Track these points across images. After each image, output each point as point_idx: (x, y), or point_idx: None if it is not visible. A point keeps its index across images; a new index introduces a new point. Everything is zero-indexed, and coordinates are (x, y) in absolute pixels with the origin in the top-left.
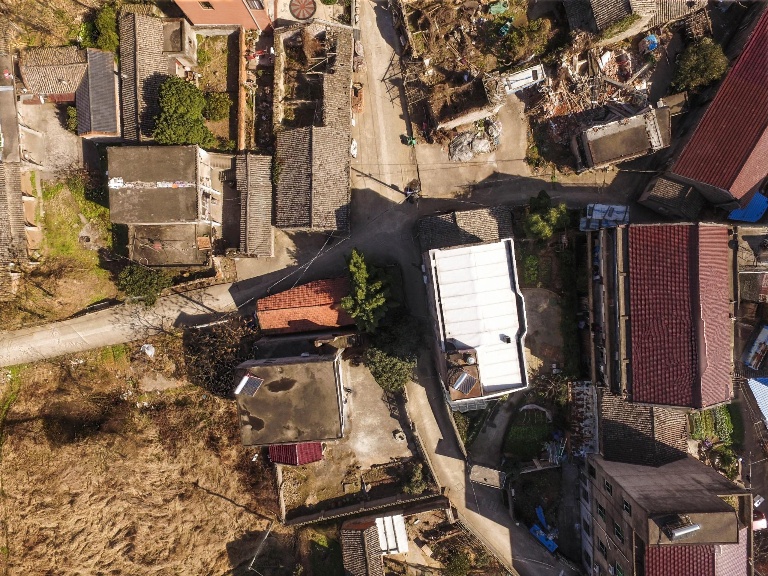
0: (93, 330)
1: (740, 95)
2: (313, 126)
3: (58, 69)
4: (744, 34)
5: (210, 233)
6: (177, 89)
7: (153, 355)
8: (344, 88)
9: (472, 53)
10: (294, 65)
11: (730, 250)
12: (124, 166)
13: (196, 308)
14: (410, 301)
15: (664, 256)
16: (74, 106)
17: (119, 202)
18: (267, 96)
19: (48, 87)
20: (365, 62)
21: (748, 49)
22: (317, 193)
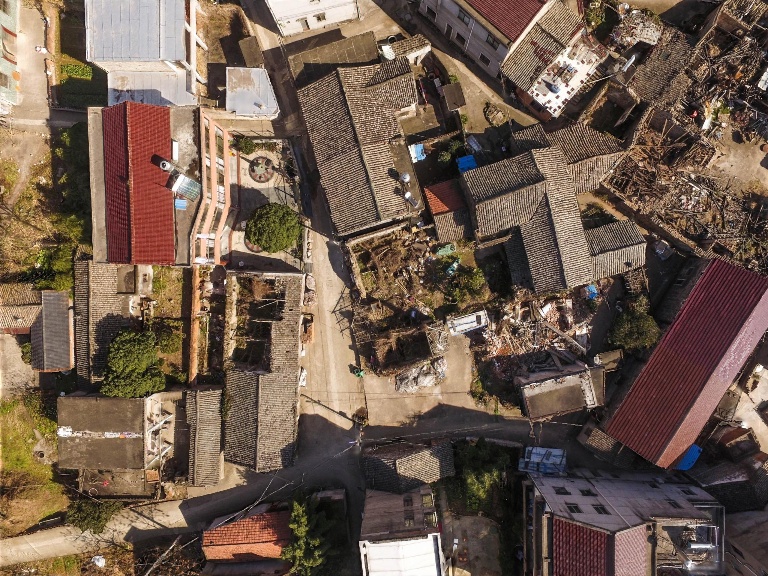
0: (45, 541)
1: (670, 368)
2: (260, 375)
3: (13, 309)
4: (679, 294)
5: (159, 466)
6: (125, 351)
7: (103, 566)
8: (292, 331)
9: (420, 292)
10: (247, 298)
11: (649, 544)
12: (73, 416)
13: (146, 523)
14: (355, 524)
15: (584, 555)
16: (29, 339)
17: (67, 450)
18: (221, 322)
19: (3, 323)
20: (315, 298)
21: (679, 321)
22: (263, 437)
